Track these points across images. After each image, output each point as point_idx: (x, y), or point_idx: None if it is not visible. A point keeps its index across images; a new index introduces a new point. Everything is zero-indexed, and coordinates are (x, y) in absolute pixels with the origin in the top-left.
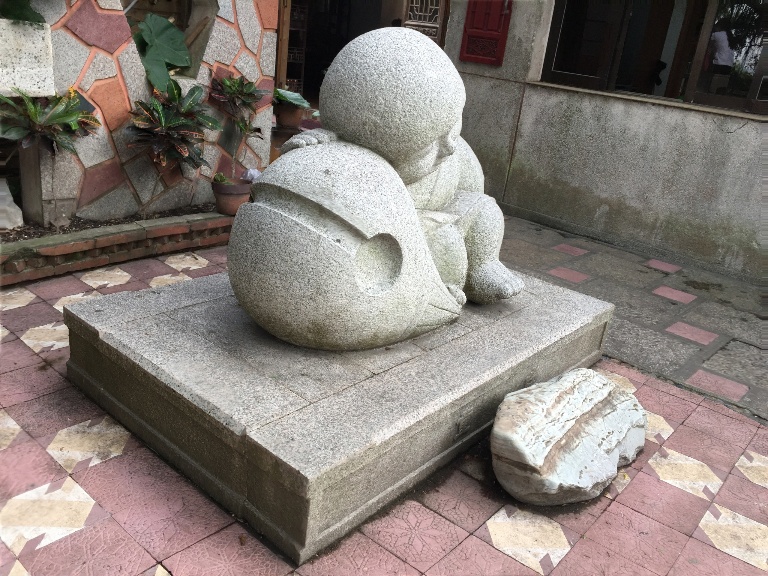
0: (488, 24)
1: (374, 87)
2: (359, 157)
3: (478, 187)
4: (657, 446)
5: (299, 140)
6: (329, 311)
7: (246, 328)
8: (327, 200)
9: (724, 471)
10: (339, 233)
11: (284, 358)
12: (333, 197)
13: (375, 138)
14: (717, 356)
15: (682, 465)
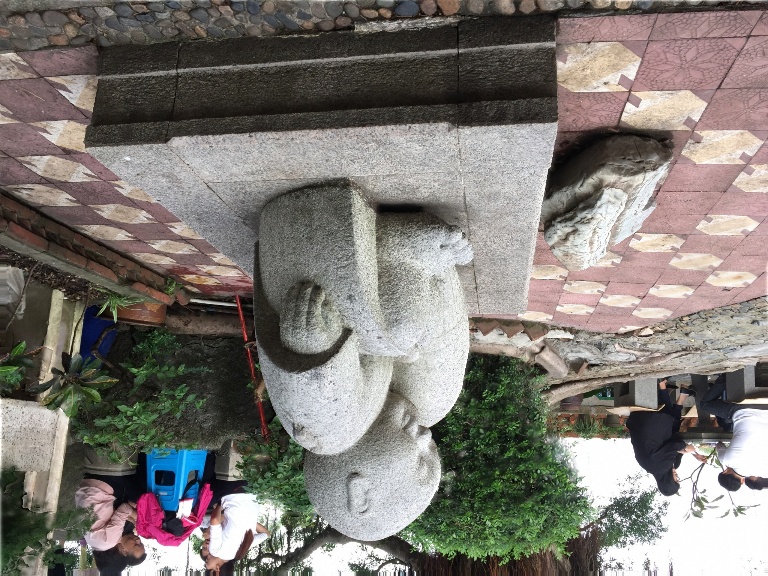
0: None
1: None
2: None
3: (355, 349)
4: (688, 134)
5: None
6: None
7: None
8: None
9: None
10: None
11: None
12: None
13: None
14: None
15: (718, 143)
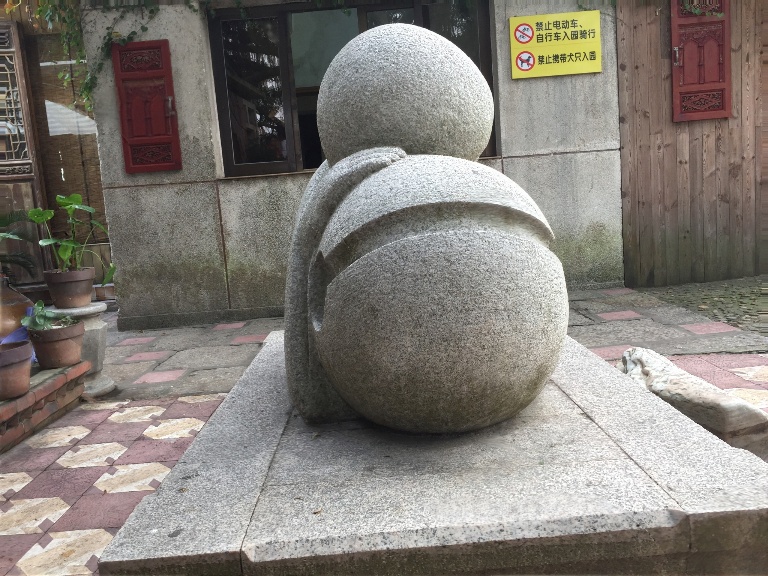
0: (152, 129)
1: (443, 77)
2: (465, 159)
3: None
4: None
5: (380, 158)
6: (555, 343)
7: (388, 447)
8: (510, 200)
9: (755, 385)
10: (531, 239)
11: (496, 446)
12: (511, 196)
13: (453, 140)
14: (575, 338)
15: None
